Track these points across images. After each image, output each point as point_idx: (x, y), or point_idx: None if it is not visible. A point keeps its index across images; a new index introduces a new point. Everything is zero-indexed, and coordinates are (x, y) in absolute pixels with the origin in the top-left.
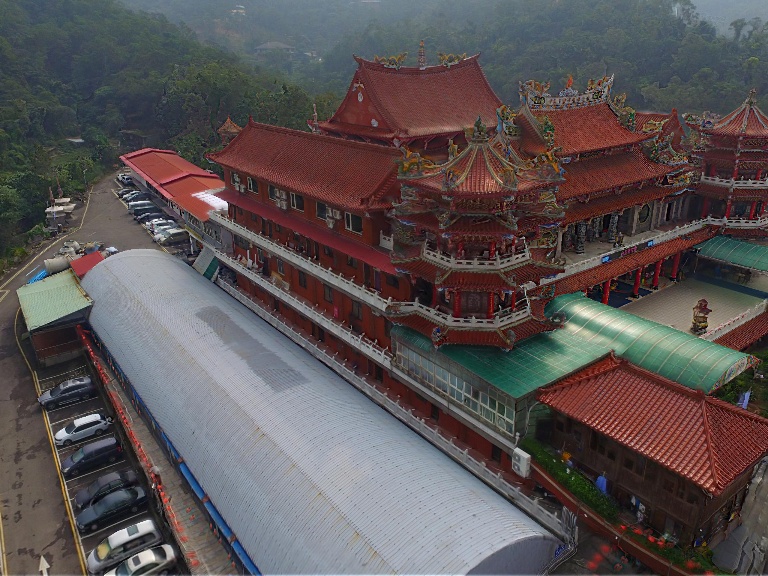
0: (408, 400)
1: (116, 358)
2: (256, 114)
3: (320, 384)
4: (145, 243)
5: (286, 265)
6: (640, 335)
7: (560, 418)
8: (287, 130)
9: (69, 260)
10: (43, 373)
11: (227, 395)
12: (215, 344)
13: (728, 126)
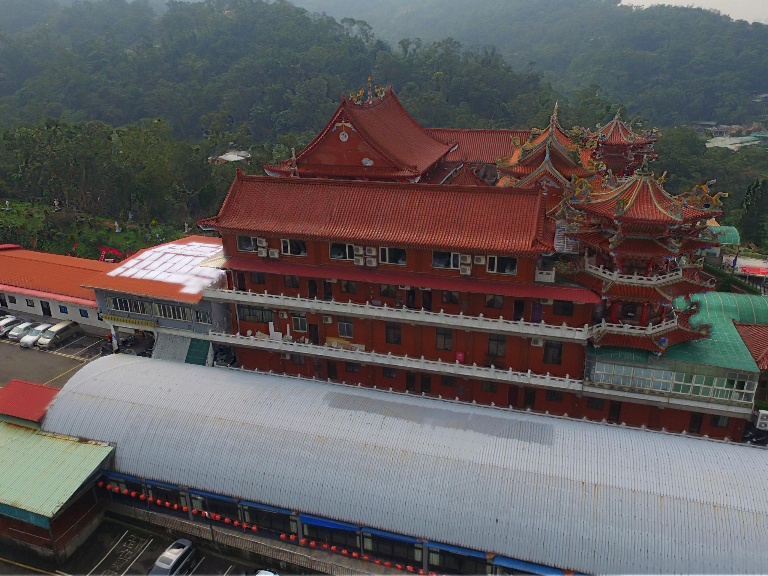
0: (578, 414)
1: (244, 495)
2: (1, 159)
3: (561, 424)
4: (13, 353)
5: (361, 326)
6: (737, 303)
7: (765, 378)
8: (324, 181)
9: None
10: (74, 568)
11: (505, 469)
12: (411, 427)
13: (612, 137)
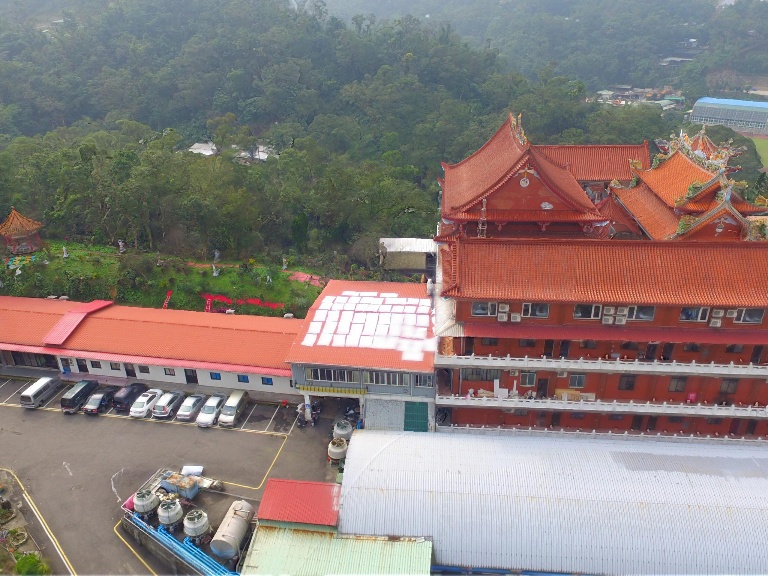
0: None
1: (586, 570)
2: None
3: None
4: (198, 437)
5: (596, 377)
6: None
7: None
8: (556, 241)
9: (244, 516)
10: None
11: None
12: (719, 482)
13: None
